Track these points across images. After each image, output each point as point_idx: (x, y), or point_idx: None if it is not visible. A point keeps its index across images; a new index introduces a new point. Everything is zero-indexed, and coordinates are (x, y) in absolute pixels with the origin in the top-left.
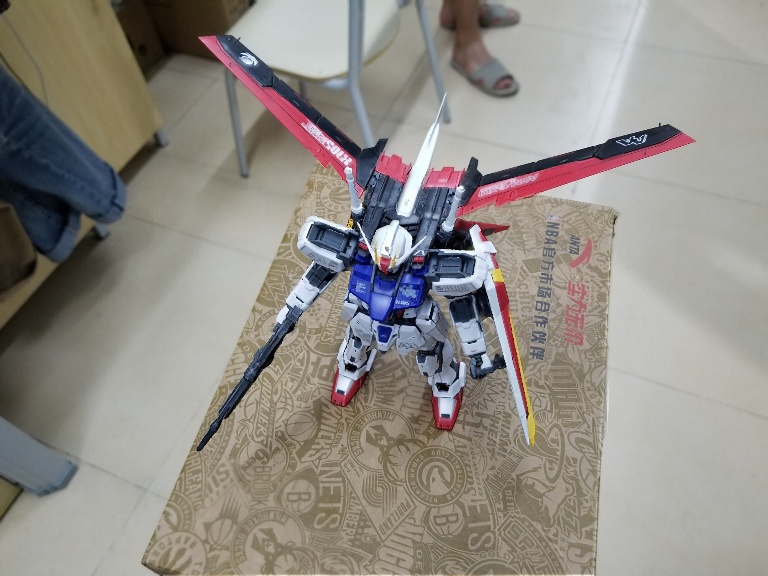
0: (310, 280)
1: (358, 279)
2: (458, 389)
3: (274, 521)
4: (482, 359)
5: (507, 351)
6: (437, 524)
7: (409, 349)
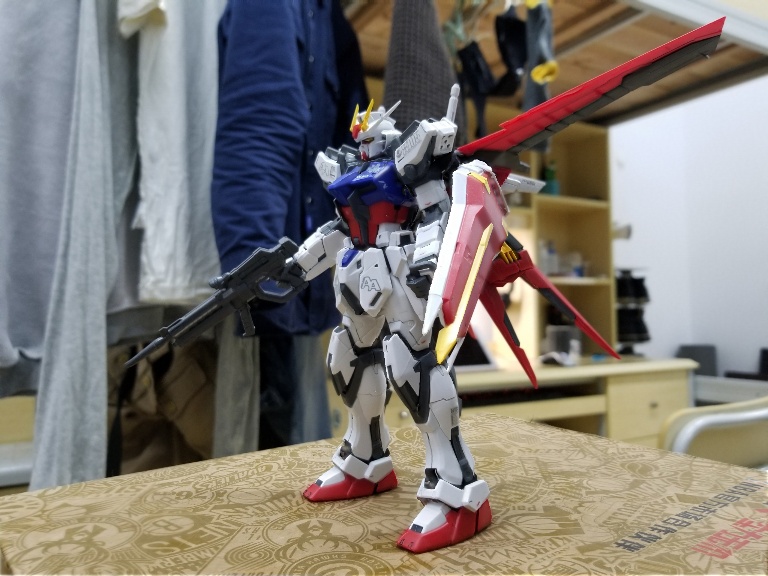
0: (323, 231)
1: None
2: (456, 502)
3: (117, 526)
4: None
5: (452, 232)
6: None
7: (371, 294)
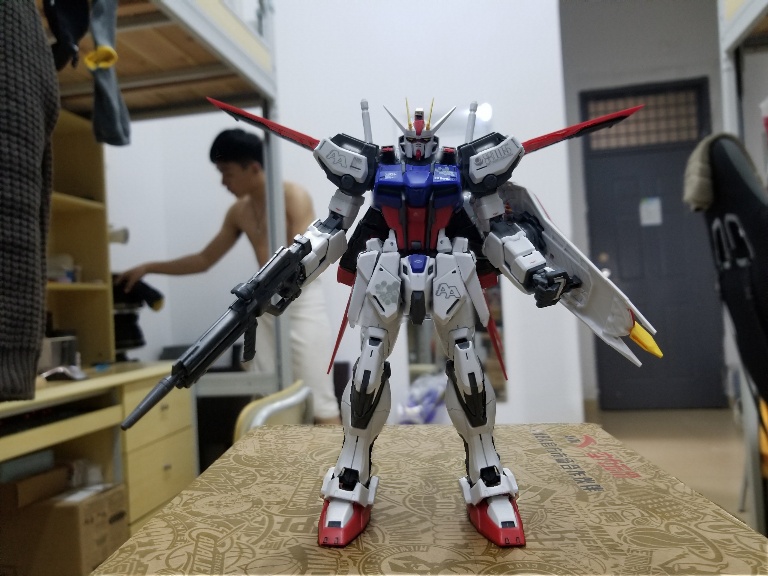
0: (318, 229)
1: (386, 172)
2: None
3: None
4: (546, 270)
5: None
6: None
7: (449, 301)
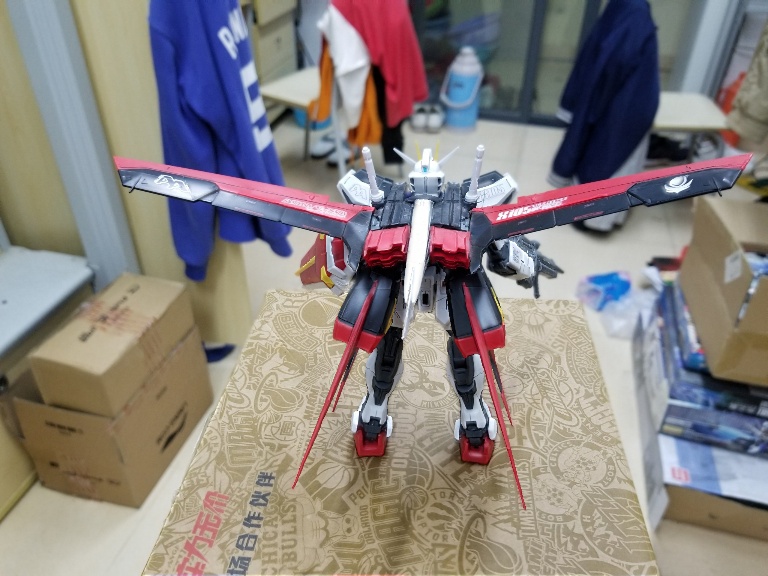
0: None
1: None
2: None
3: None
4: None
5: None
6: None
7: None
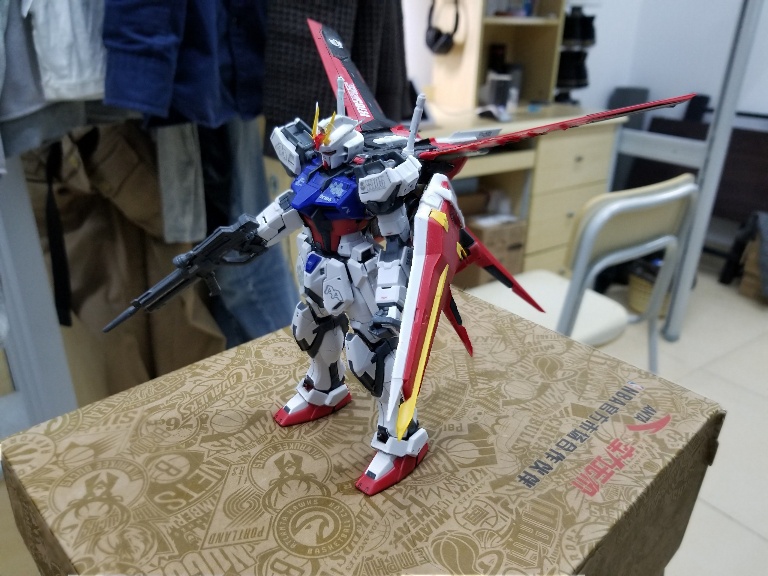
0: (281, 202)
1: (303, 175)
2: (402, 452)
3: (126, 473)
4: (389, 310)
5: (412, 296)
6: (272, 567)
7: (334, 301)
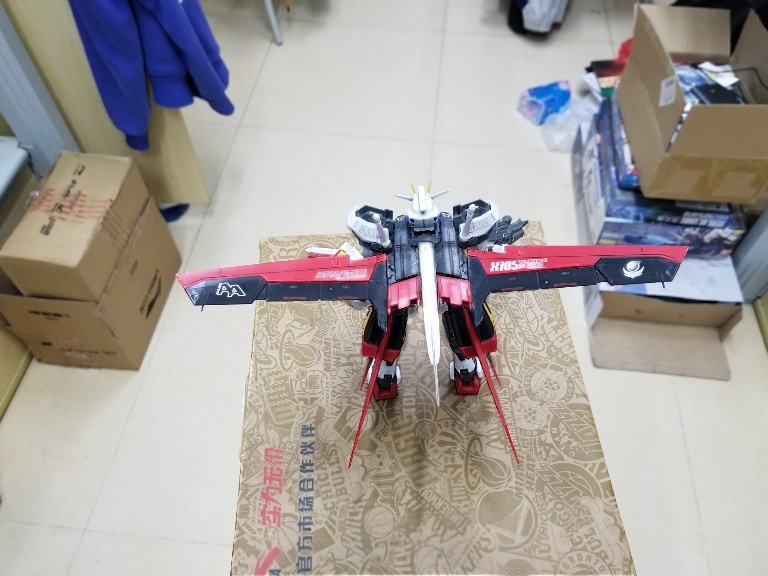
0: None
1: None
2: None
3: None
4: None
5: None
6: None
7: None
